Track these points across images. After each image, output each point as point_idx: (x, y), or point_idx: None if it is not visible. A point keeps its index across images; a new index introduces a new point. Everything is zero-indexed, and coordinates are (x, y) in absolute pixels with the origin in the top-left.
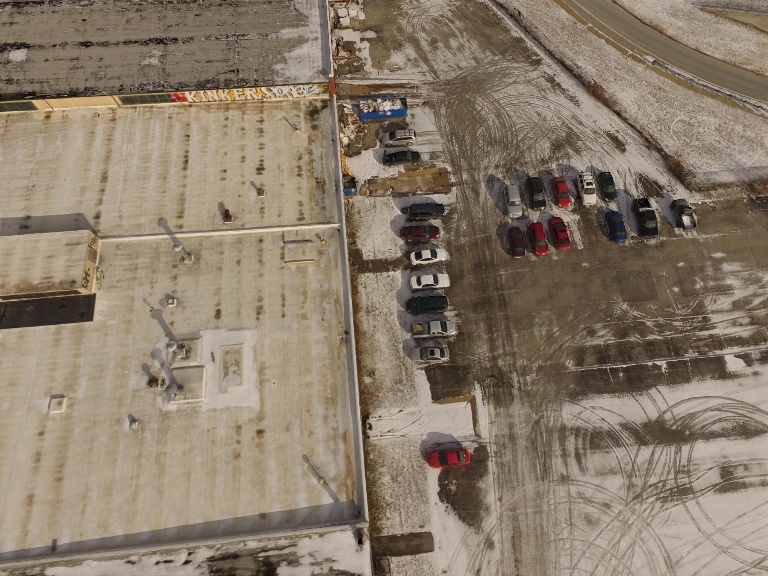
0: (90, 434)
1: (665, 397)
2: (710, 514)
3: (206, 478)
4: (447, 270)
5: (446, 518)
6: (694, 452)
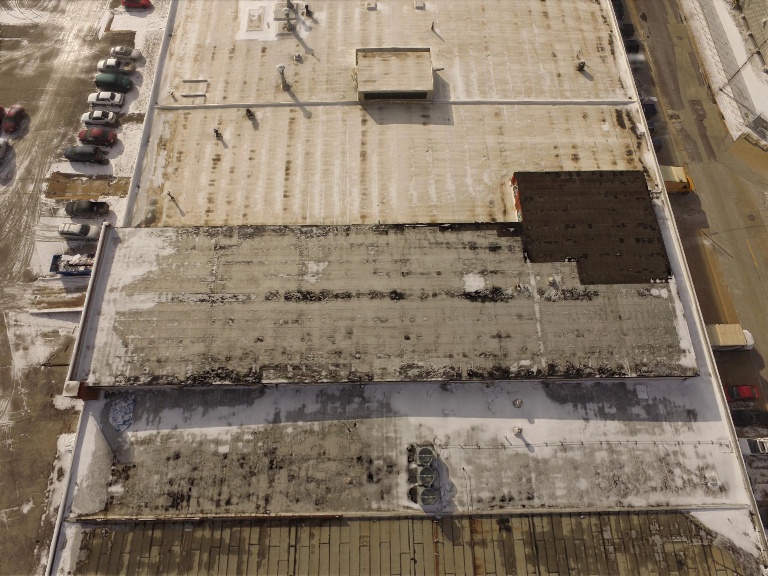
0: None
1: None
2: None
3: None
4: (88, 109)
5: None
6: None
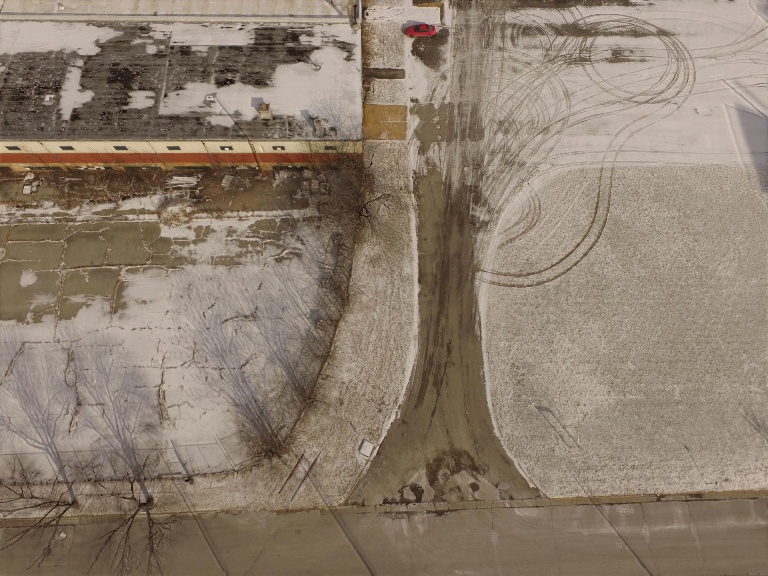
0: None
1: (581, 12)
2: (600, 72)
3: None
4: None
5: (415, 63)
6: (596, 41)
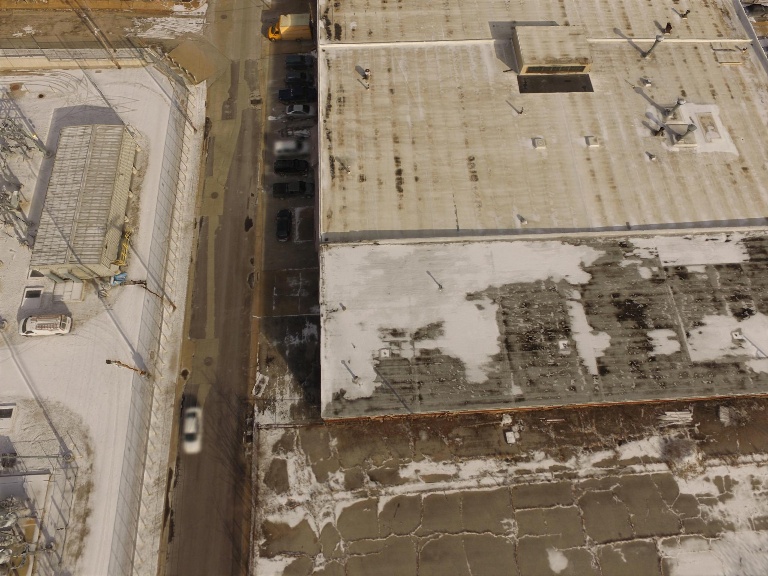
0: (623, 162)
1: None
2: None
3: (718, 194)
4: None
5: None
6: None
